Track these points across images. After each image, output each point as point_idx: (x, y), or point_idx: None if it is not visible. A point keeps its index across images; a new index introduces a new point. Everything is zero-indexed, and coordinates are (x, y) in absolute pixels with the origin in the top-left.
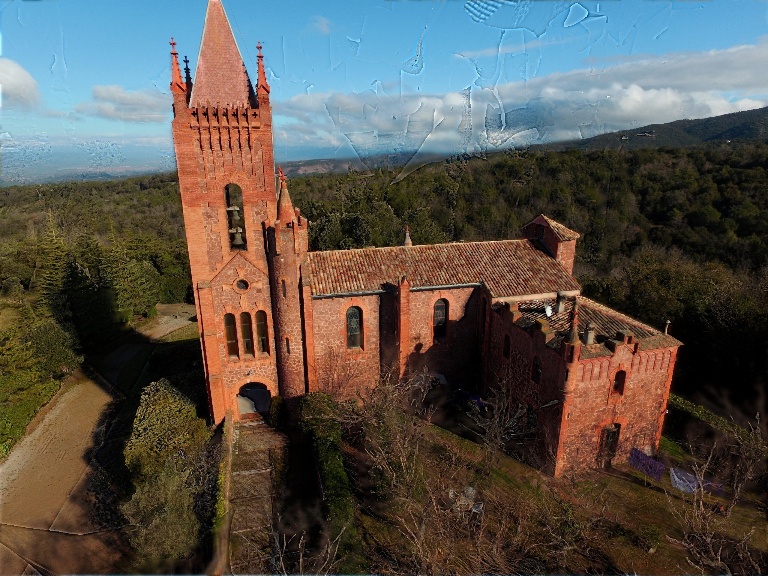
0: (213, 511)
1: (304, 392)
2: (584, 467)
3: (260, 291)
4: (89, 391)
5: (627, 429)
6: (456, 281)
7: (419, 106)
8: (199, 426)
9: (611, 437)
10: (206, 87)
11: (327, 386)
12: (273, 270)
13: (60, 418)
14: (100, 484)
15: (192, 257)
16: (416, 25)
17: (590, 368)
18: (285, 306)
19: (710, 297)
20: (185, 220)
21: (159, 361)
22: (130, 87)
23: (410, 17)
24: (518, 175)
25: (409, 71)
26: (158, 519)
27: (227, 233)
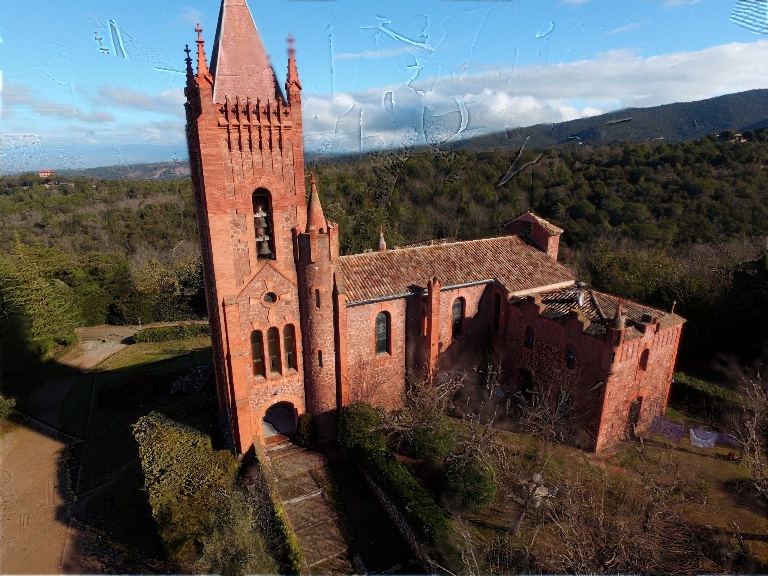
0: (285, 547)
1: (335, 405)
2: (616, 440)
3: (288, 303)
4: (27, 439)
5: (646, 400)
6: (473, 279)
7: (351, 106)
8: (227, 458)
9: (635, 409)
10: (230, 81)
11: (356, 396)
12: (305, 279)
13: (1, 477)
14: (98, 545)
15: (217, 271)
16: (476, 28)
17: (626, 349)
18: (318, 317)
19: (661, 279)
20: (210, 230)
21: (112, 393)
22: (13, 75)
23: (475, 20)
24: (449, 175)
25: (461, 73)
26: (249, 567)
27: (255, 242)
